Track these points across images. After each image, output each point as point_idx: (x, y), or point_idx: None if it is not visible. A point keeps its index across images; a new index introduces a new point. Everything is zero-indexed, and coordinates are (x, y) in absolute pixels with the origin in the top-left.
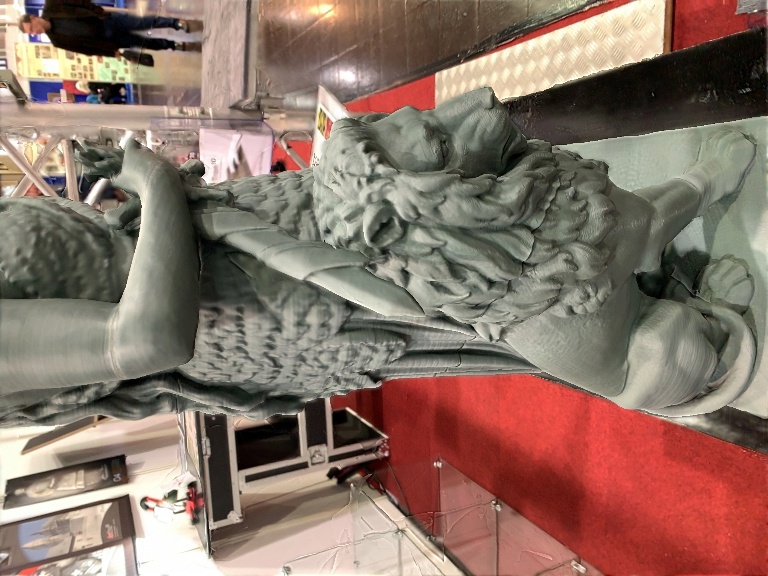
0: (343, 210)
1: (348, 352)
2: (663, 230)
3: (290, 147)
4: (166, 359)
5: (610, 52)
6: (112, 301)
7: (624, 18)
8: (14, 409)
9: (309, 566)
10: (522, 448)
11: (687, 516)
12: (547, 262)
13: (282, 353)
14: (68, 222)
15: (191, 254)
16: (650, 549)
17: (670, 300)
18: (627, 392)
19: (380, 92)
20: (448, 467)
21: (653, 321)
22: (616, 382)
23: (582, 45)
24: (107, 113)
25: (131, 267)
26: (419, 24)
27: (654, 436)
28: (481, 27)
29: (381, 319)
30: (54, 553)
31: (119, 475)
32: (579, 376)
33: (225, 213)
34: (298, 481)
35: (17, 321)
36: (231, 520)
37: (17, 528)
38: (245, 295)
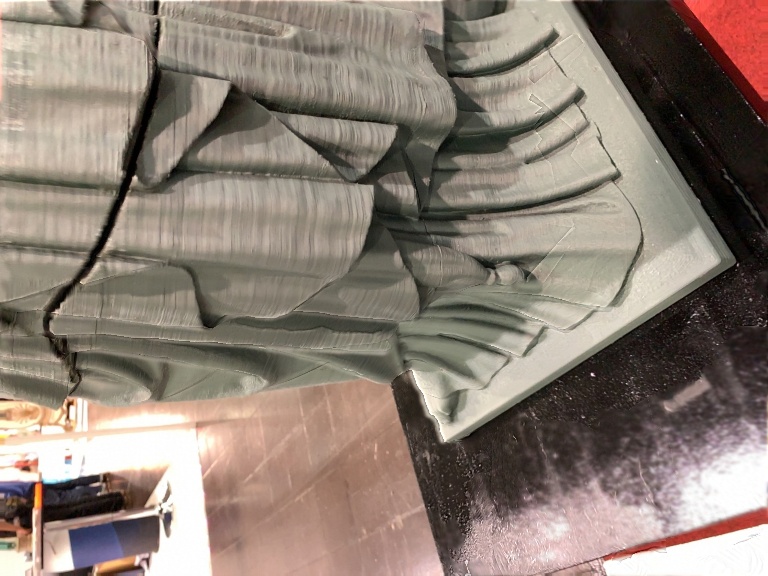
0: None
1: None
2: None
3: None
4: None
5: None
6: None
7: None
8: None
9: None
10: None
11: None
12: None
13: None
14: None
15: None
16: None
17: None
18: None
19: None
20: None
21: None
22: None
23: None
24: None
25: None
26: None
27: None
28: None
29: None
30: None
31: None
32: None
33: None
34: None
35: None
36: None
37: None
38: None
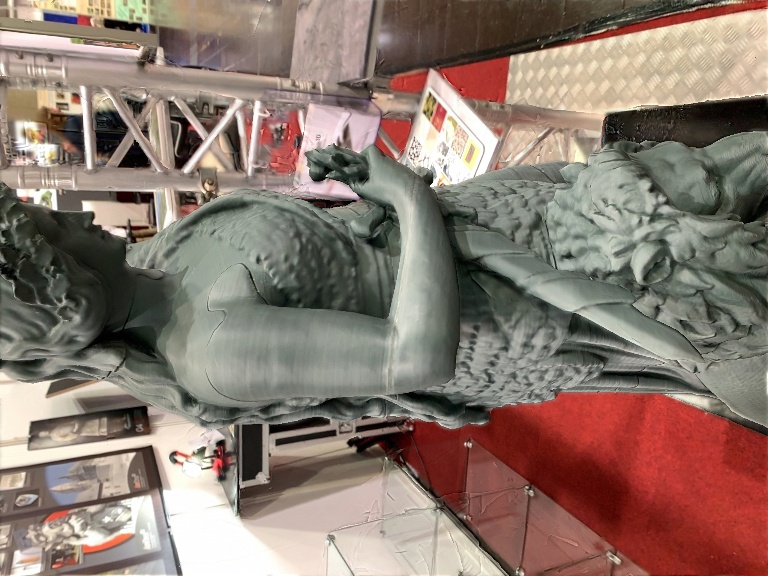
0: (612, 244)
1: (556, 372)
2: None
3: None
4: (435, 380)
5: (718, 58)
6: (358, 311)
7: (739, 25)
8: (257, 409)
9: (352, 536)
10: (564, 439)
11: (740, 523)
12: None
13: (500, 370)
14: (322, 228)
15: (456, 275)
16: (695, 550)
17: None
18: None
19: (443, 67)
20: (479, 448)
21: None
22: None
23: (687, 47)
24: (222, 80)
25: (401, 284)
26: (495, 2)
27: (714, 444)
28: (568, 14)
29: (592, 343)
30: (83, 498)
31: (141, 426)
32: (762, 410)
33: (478, 233)
34: (320, 447)
35: (301, 333)
36: (259, 481)
37: (44, 470)
38: (483, 314)
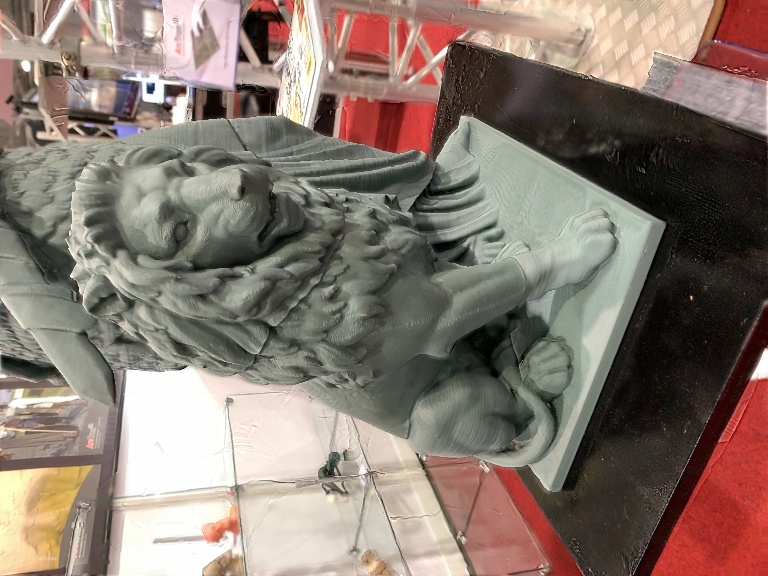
0: None
1: (129, 357)
2: (454, 327)
3: (283, 4)
4: None
5: None
6: None
7: None
8: None
9: (251, 402)
10: None
11: None
12: (286, 356)
13: None
14: None
15: None
16: None
17: (469, 377)
18: (410, 441)
19: None
20: None
21: (436, 398)
22: (399, 432)
23: None
24: None
25: None
26: None
27: None
28: None
29: None
30: None
31: None
32: None
33: None
34: None
35: None
36: None
37: None
38: None
